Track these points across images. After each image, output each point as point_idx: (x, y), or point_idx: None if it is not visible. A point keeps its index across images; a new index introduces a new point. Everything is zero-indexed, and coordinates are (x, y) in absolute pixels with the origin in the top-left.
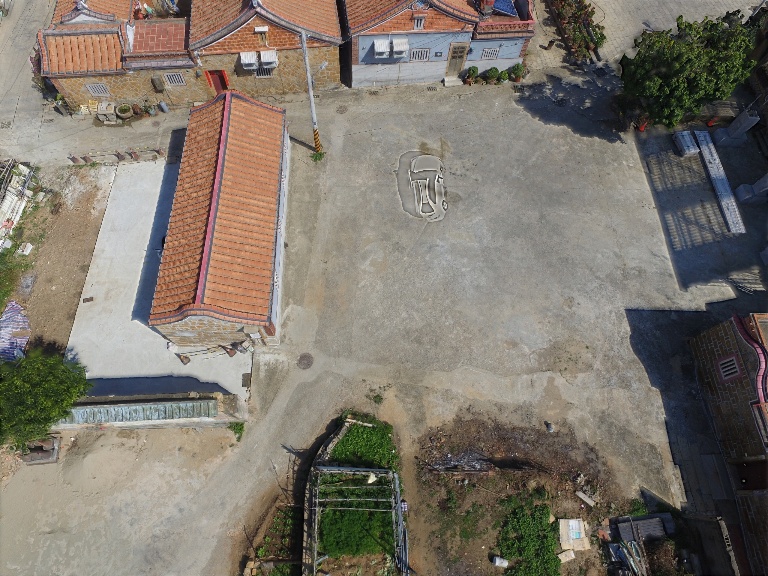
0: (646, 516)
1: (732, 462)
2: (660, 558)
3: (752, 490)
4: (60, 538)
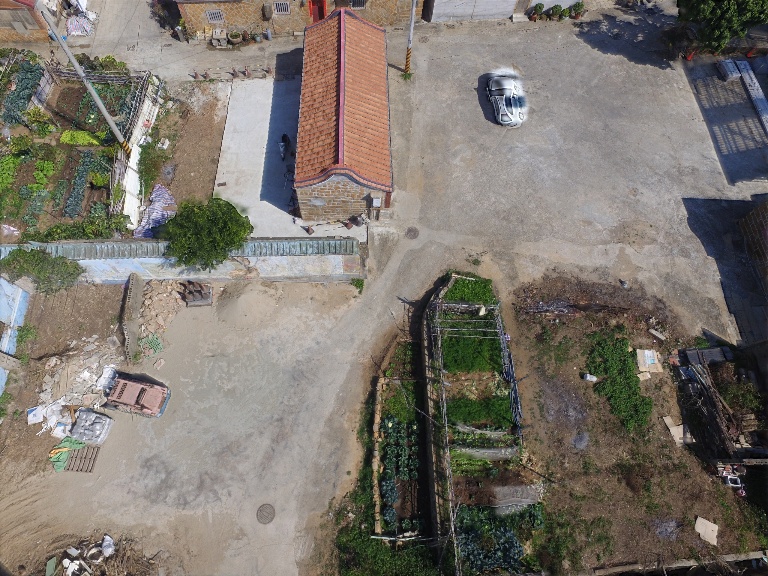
0: (709, 348)
1: None
2: (723, 374)
3: None
4: (221, 360)
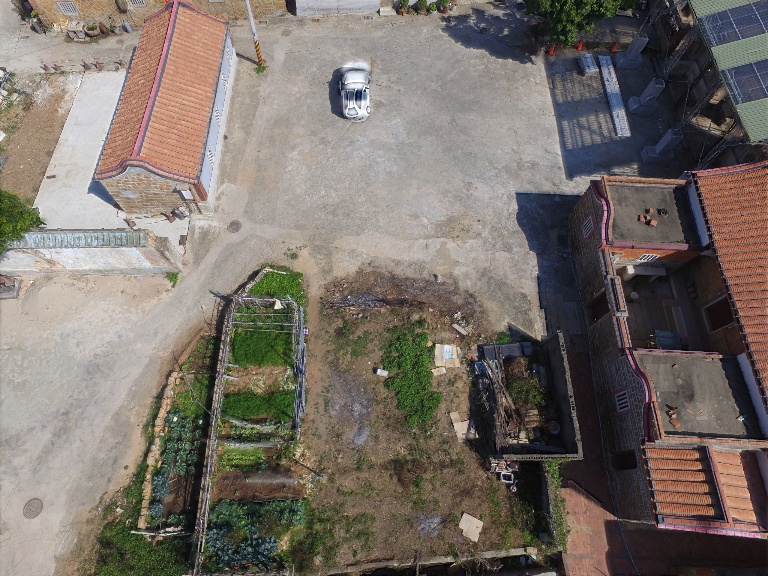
0: (509, 343)
1: (588, 305)
2: (514, 370)
3: (597, 321)
4: (17, 353)
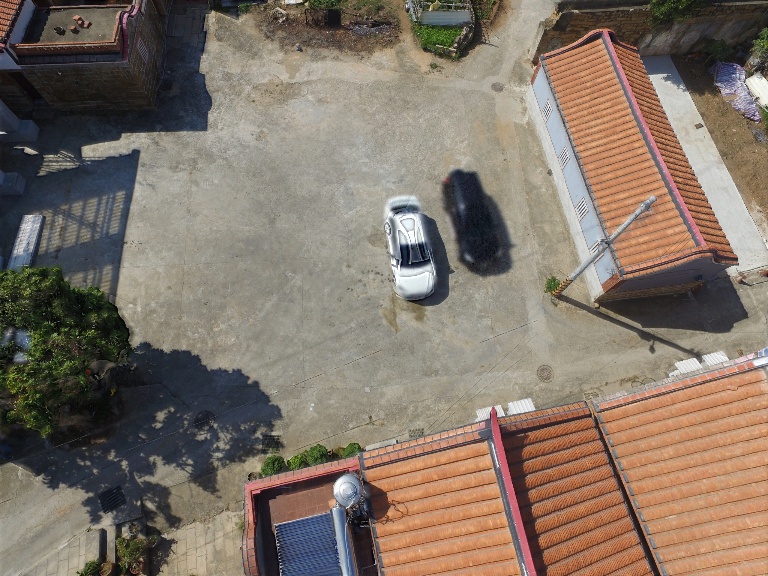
0: (241, 3)
1: None
2: None
3: None
4: None
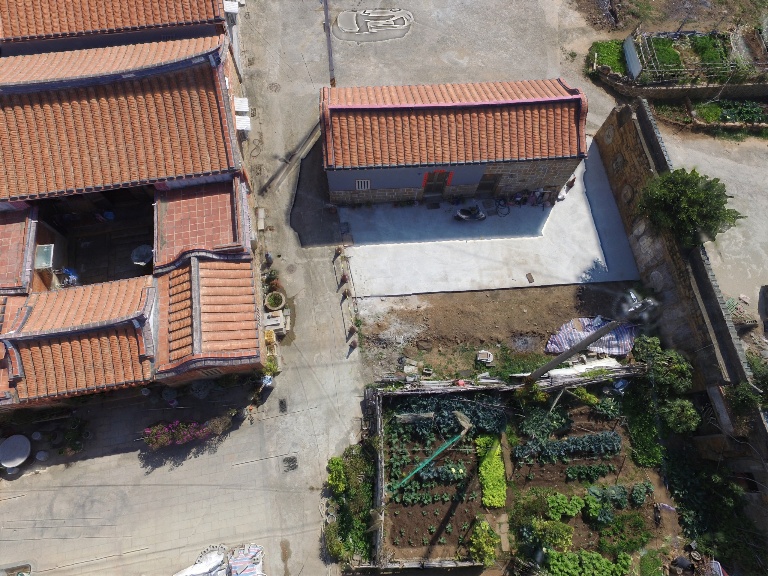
0: None
1: None
2: None
3: None
4: (721, 247)
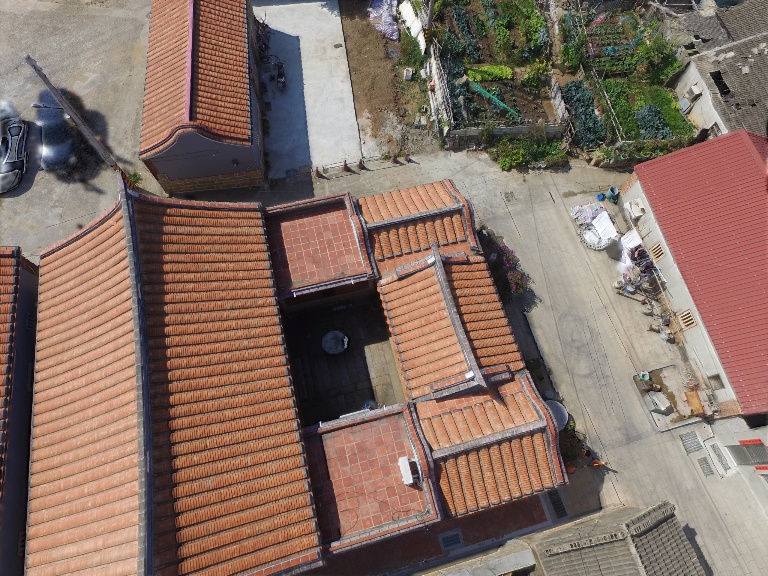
0: None
1: None
2: None
3: None
4: None
